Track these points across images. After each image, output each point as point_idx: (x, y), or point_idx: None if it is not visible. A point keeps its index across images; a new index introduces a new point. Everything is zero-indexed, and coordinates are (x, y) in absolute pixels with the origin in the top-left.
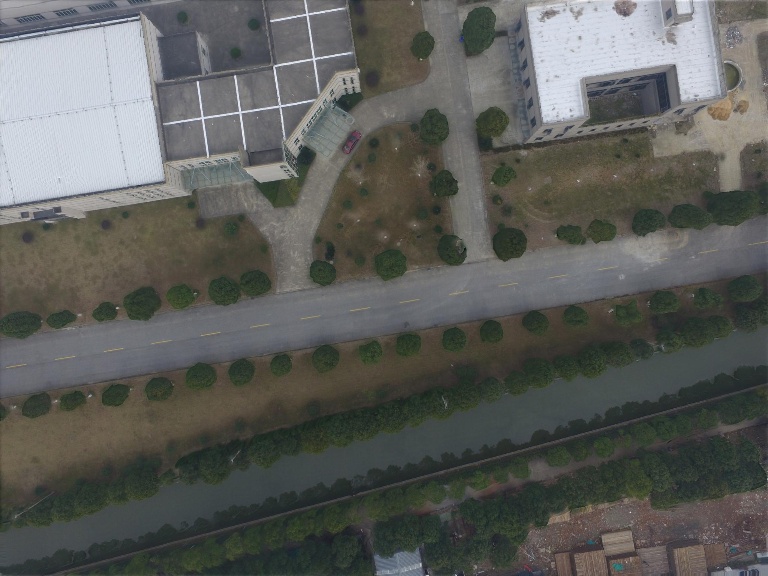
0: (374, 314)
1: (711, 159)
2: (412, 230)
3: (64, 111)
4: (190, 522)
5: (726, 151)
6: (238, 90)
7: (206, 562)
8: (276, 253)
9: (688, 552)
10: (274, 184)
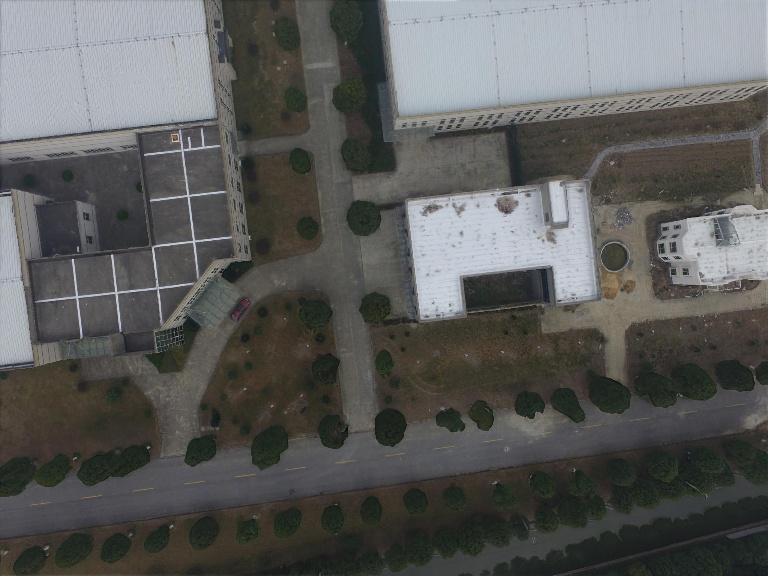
0: (259, 481)
1: (597, 337)
2: (299, 399)
3: None
4: None
5: (612, 329)
6: (115, 270)
7: None
8: (161, 417)
9: None
10: None
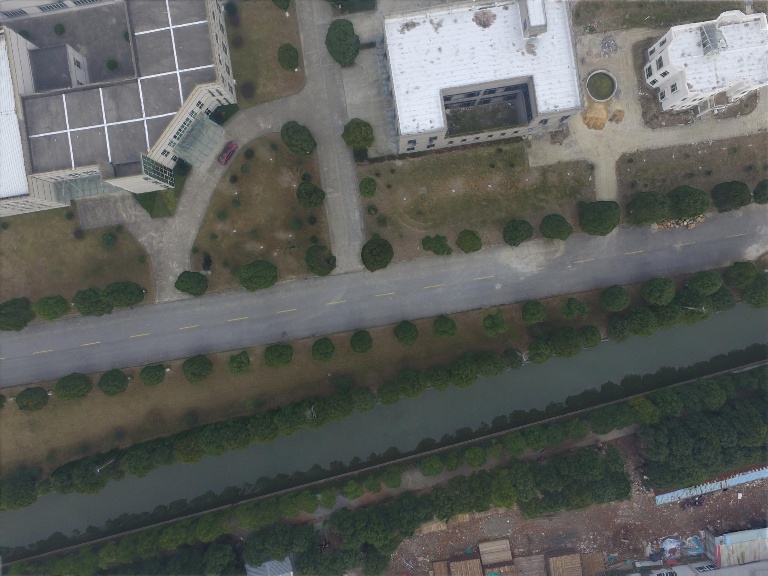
0: (252, 324)
1: (586, 169)
2: (288, 240)
3: None
4: (82, 530)
5: (602, 160)
6: (103, 103)
7: (79, 571)
8: (155, 263)
9: (564, 561)
10: (151, 195)
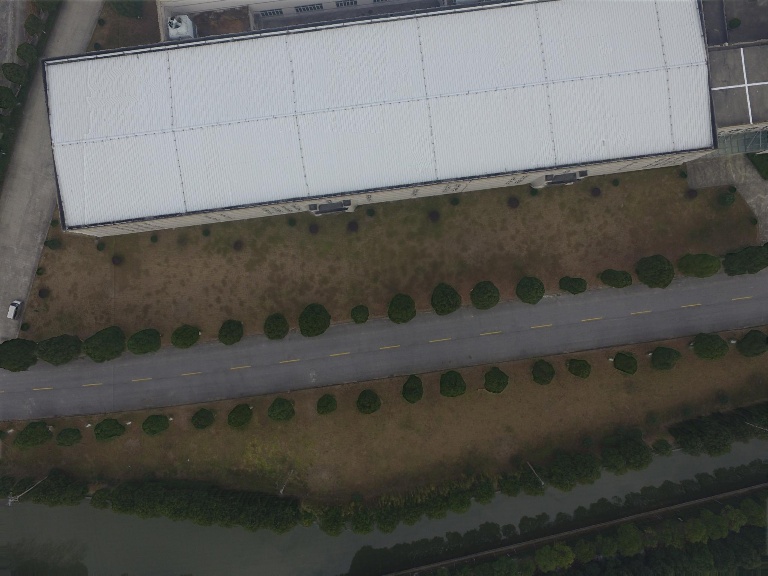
0: None
1: None
2: None
3: (616, 73)
4: (622, 497)
5: None
6: None
7: (715, 533)
8: (761, 226)
9: None
10: (767, 156)
